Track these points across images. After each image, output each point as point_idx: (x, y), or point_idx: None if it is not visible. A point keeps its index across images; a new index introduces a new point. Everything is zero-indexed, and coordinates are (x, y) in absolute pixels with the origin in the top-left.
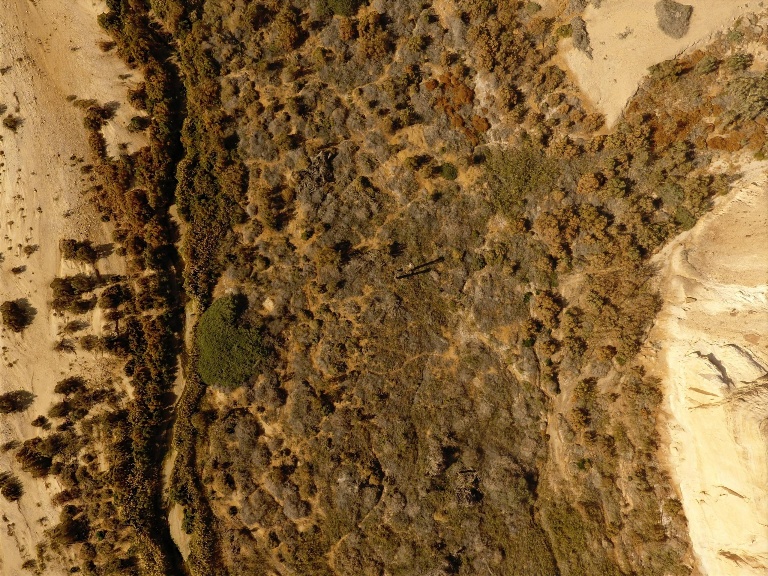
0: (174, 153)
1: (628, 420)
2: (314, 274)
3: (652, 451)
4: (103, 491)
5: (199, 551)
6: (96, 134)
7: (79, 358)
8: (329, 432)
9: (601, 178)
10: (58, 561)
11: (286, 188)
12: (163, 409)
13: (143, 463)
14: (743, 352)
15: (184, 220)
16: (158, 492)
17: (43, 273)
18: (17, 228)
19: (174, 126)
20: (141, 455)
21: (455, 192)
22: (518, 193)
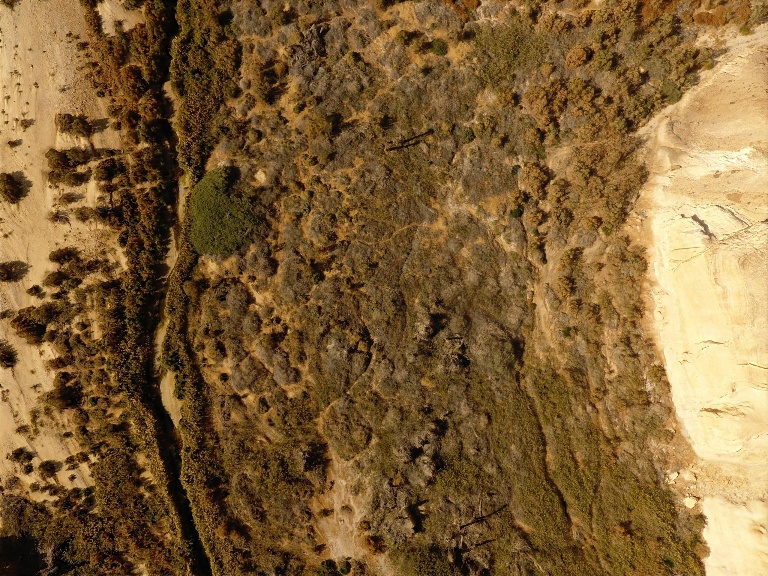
0: (169, 30)
1: (613, 289)
2: (305, 146)
3: (636, 318)
4: (96, 358)
5: (190, 414)
6: (92, 11)
7: (73, 229)
8: (319, 300)
9: (589, 50)
10: (51, 427)
11: (279, 62)
12: (156, 279)
13: (136, 330)
14: (725, 210)
15: (178, 94)
16: (150, 360)
17: (39, 147)
18: (14, 103)
19: (169, 3)
20: (134, 322)
21: (445, 67)
22: (507, 67)
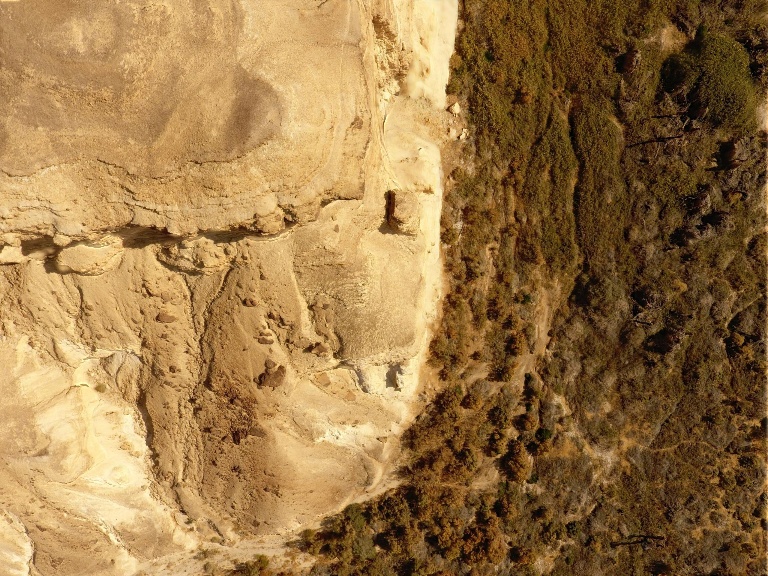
0: None
1: (468, 331)
2: (751, 567)
3: (456, 297)
4: None
5: None
6: None
7: None
8: None
9: None
10: None
11: None
12: None
13: None
14: (364, 387)
15: None
16: None
17: None
18: None
19: None
20: None
21: None
22: None
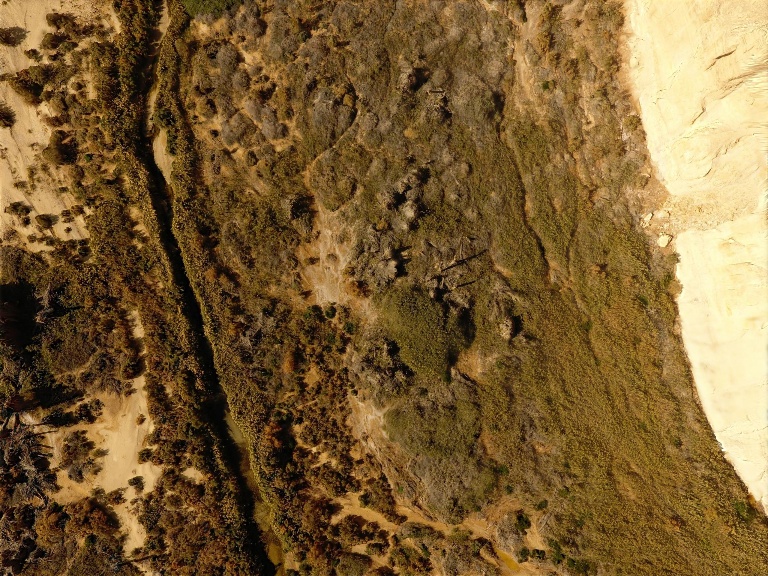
0: None
1: (591, 44)
2: None
3: (613, 68)
4: None
5: (181, 164)
6: None
7: None
8: (306, 58)
9: None
10: (48, 183)
11: None
12: (149, 43)
13: (129, 87)
14: None
15: None
16: (143, 120)
17: None
18: None
19: None
20: (127, 79)
21: None
22: None
